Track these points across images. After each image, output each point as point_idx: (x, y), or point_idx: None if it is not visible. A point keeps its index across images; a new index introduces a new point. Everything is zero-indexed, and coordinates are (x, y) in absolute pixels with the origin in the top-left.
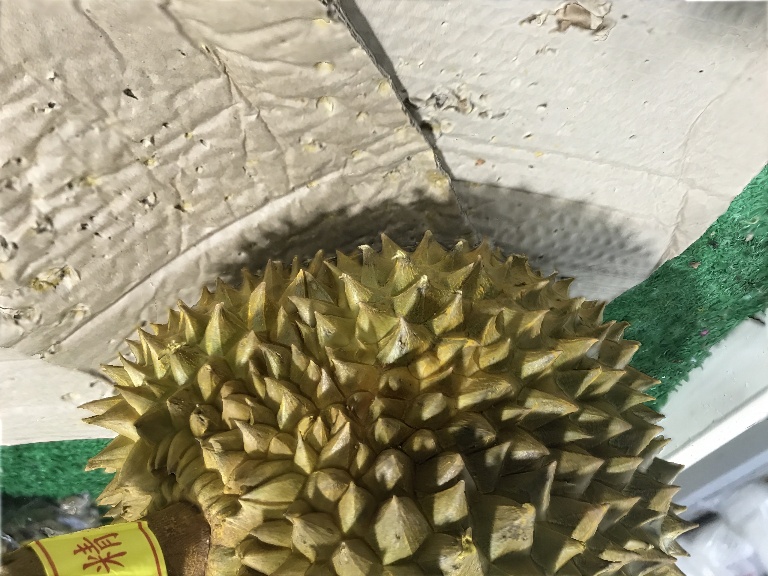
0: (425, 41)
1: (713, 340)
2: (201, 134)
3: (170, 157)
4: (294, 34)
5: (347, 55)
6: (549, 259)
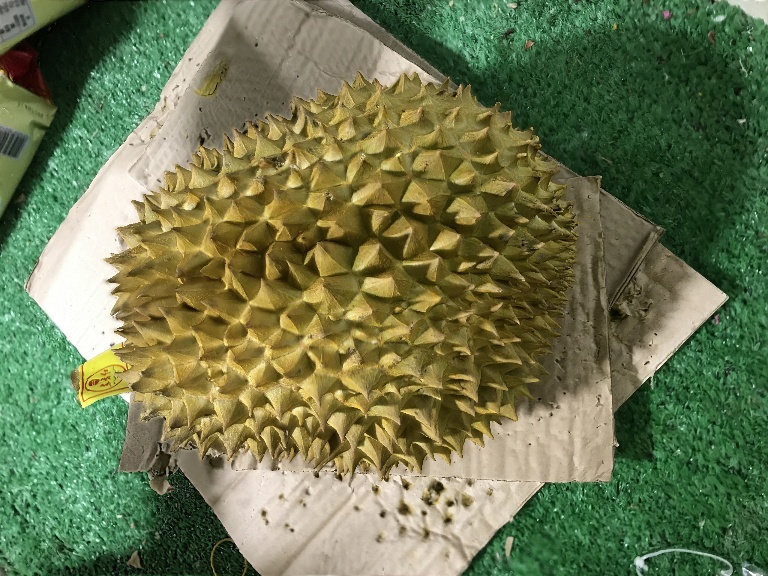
0: None
1: (695, 2)
2: None
3: None
4: None
5: None
6: None
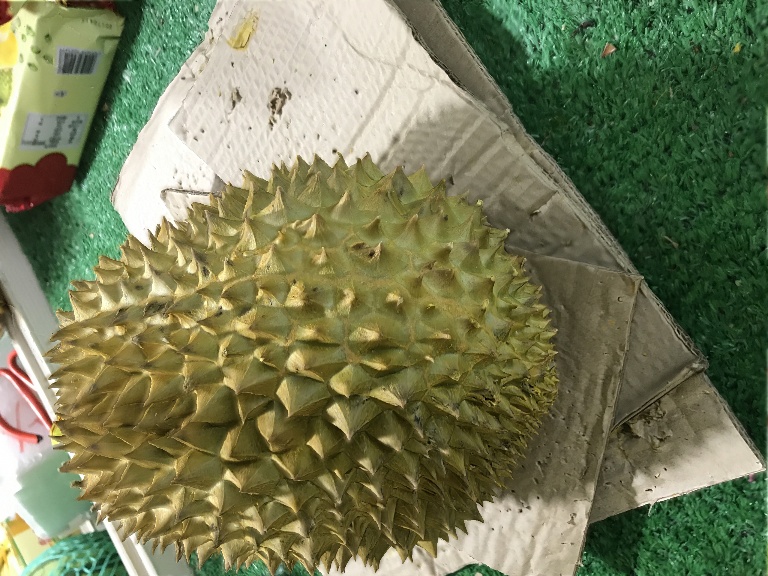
0: (264, 172)
1: None
2: None
3: None
4: None
5: None
6: None
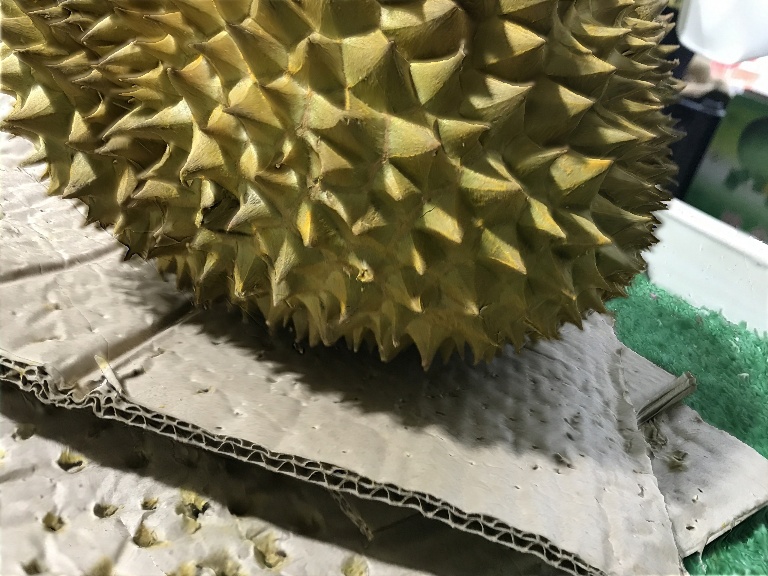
0: None
1: None
2: (39, 207)
3: (20, 217)
4: None
5: None
6: None
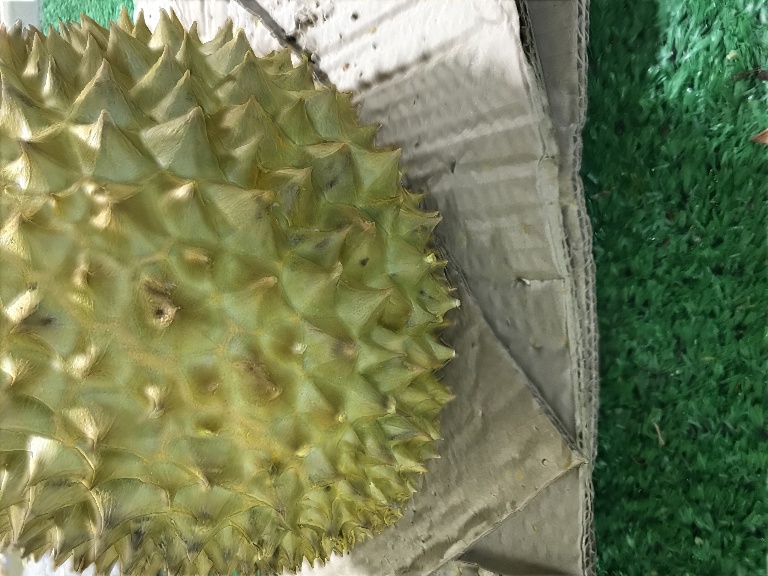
0: None
1: None
2: None
3: None
4: (209, 8)
5: (228, 6)
6: (423, 144)
